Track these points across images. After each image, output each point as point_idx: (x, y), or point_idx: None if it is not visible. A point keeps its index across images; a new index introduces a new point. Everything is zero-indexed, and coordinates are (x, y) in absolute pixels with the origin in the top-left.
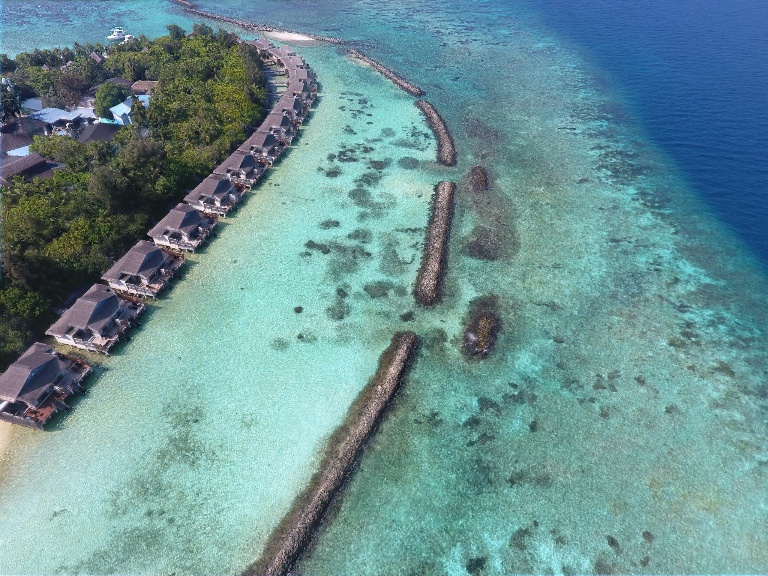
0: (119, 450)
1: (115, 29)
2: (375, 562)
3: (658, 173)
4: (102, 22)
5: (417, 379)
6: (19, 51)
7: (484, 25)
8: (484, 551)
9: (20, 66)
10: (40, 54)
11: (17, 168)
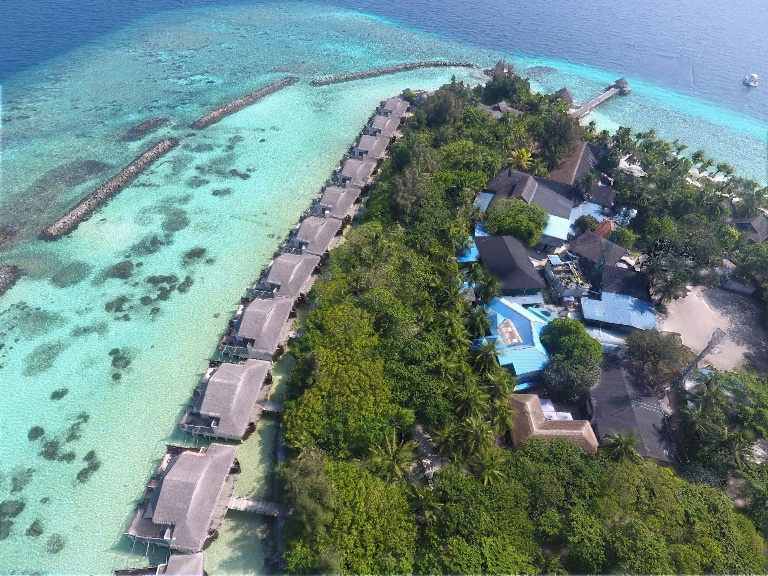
0: None
1: None
2: None
3: None
4: None
5: None
6: None
7: None
8: (206, 83)
9: None
10: None
11: None
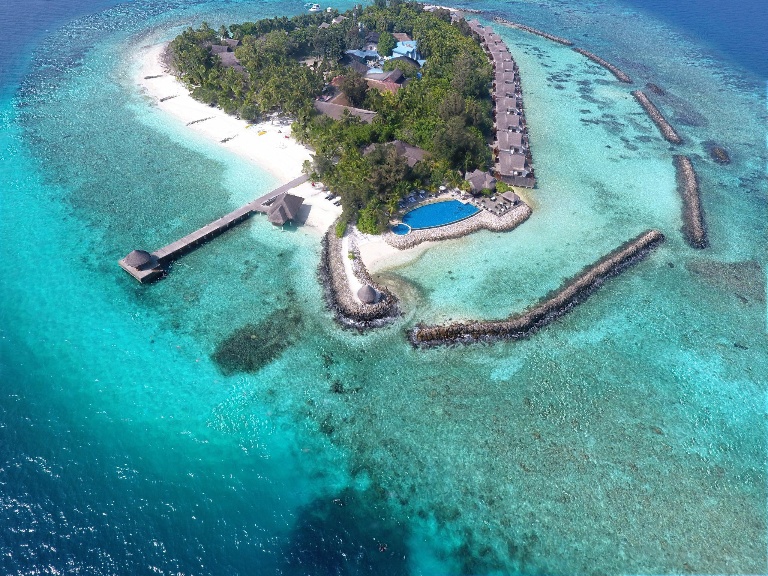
0: (577, 195)
1: (314, 4)
2: (737, 226)
3: (765, 86)
4: (286, 0)
5: (700, 172)
6: (255, 20)
7: (573, 0)
8: None
9: (297, 25)
10: (305, 17)
11: (396, 76)
